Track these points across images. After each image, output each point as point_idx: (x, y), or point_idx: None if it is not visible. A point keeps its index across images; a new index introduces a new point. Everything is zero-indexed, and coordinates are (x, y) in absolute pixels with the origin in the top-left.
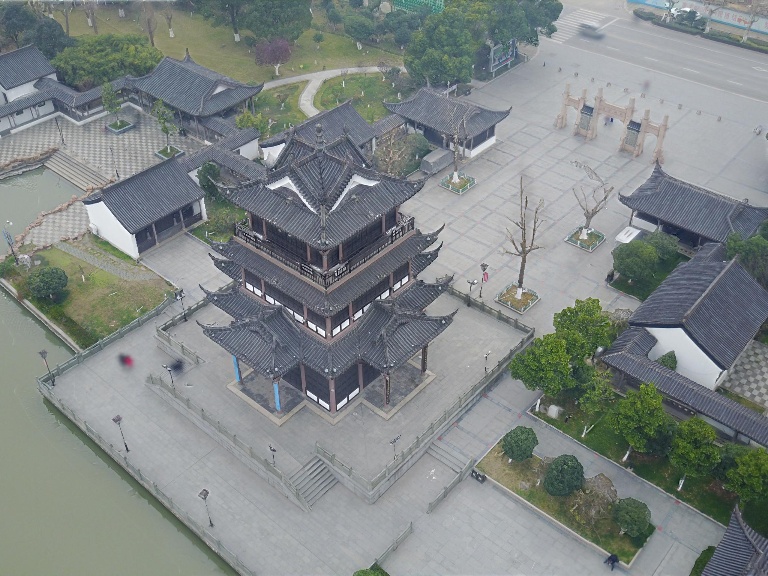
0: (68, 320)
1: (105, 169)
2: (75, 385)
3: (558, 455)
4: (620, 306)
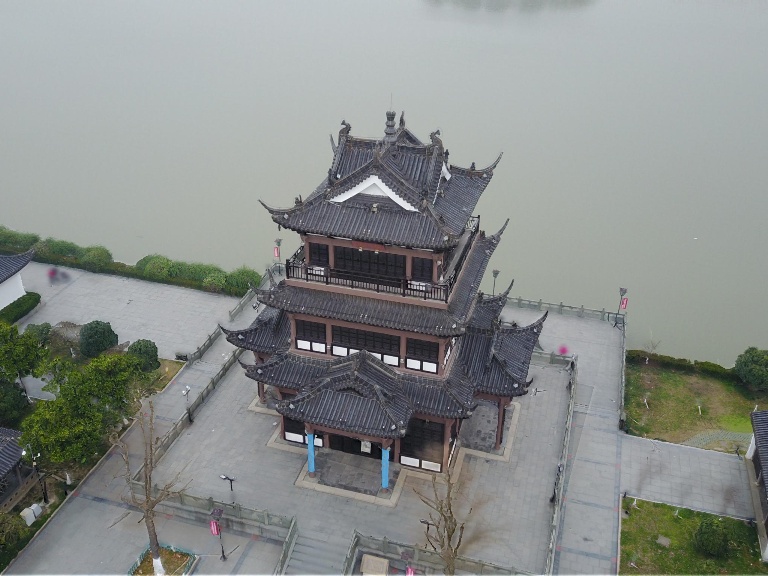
0: (688, 363)
1: None
2: (599, 331)
3: None
4: None
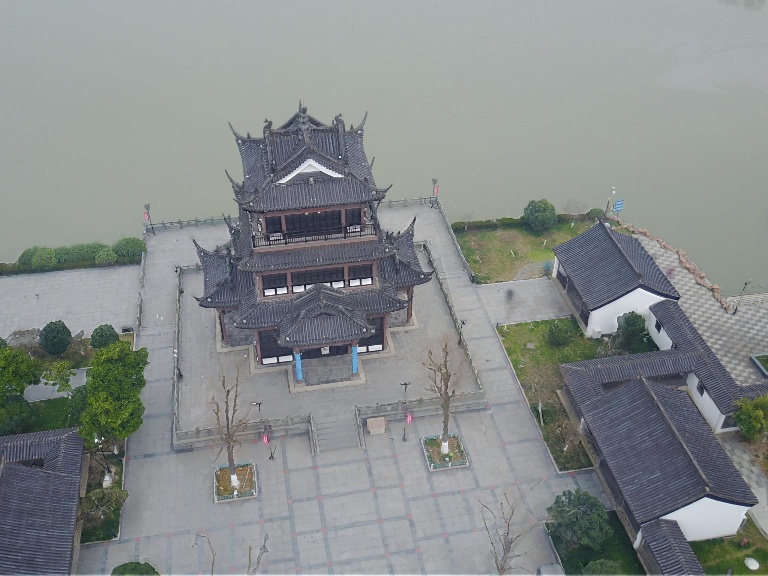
0: (493, 222)
1: (760, 310)
2: (423, 215)
3: (83, 378)
4: (126, 562)
